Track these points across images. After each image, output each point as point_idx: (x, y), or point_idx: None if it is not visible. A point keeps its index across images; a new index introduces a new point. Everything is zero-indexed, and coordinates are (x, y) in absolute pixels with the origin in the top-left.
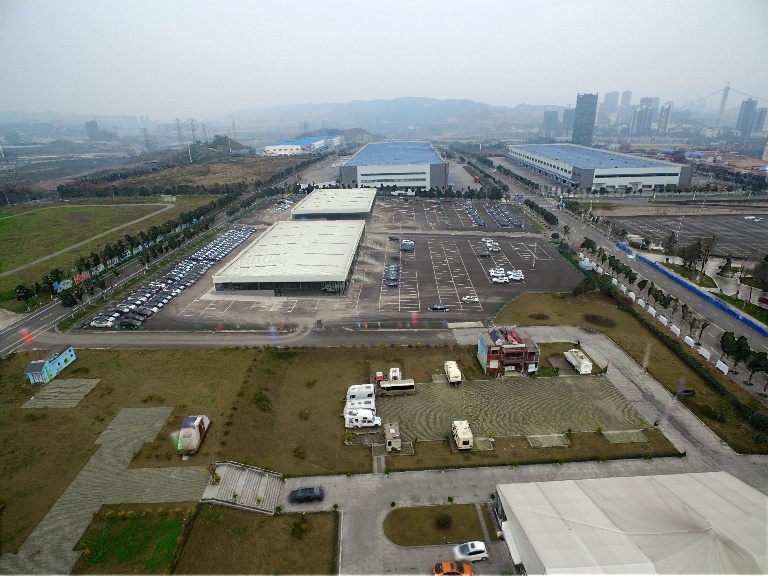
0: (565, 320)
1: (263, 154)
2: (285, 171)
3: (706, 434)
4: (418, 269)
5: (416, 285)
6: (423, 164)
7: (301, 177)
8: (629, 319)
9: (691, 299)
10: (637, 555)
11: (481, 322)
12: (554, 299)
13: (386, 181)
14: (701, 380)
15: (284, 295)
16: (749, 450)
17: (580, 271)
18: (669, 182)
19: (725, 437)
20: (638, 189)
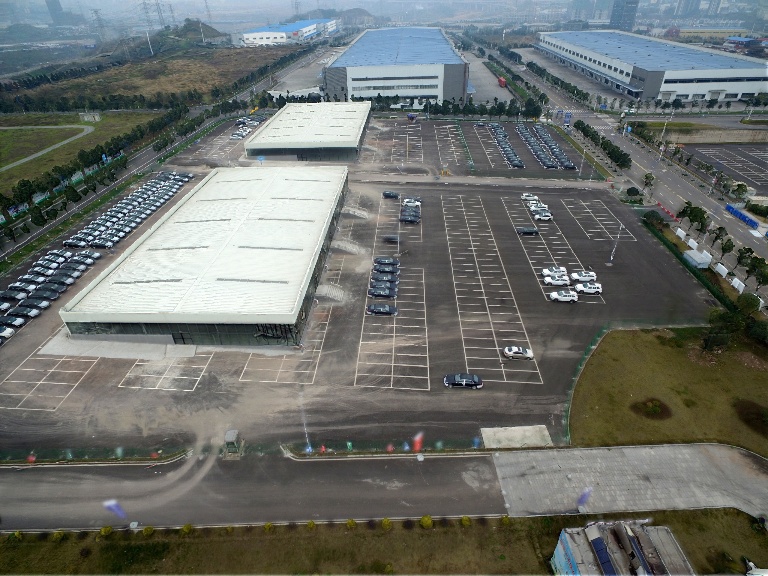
0: (704, 422)
1: (241, 44)
2: (257, 71)
3: None
4: (426, 266)
5: (423, 308)
6: (435, 64)
7: (278, 80)
8: None
9: None
10: None
11: (545, 428)
12: (664, 348)
13: (385, 88)
14: None
15: (191, 342)
16: None
17: (687, 269)
18: (763, 90)
19: None
20: (719, 99)
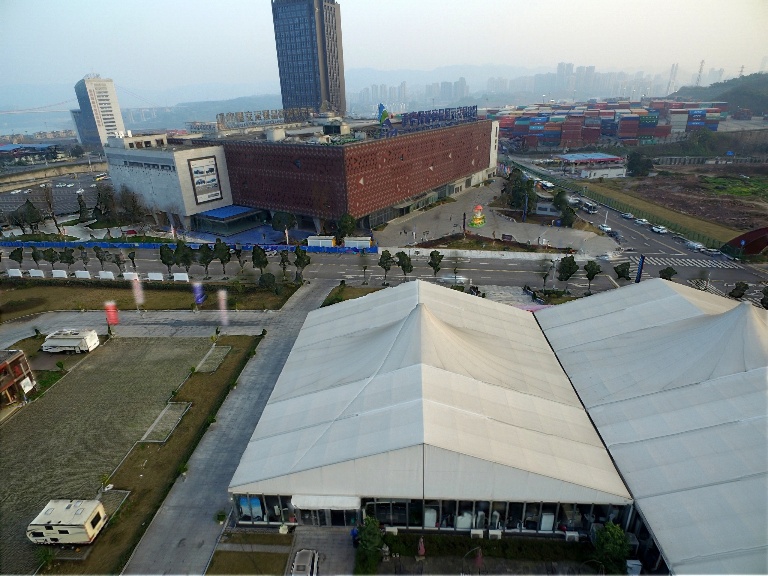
0: None
1: None
2: None
3: (249, 314)
4: None
5: None
6: None
7: None
8: (48, 289)
9: (75, 253)
10: (409, 371)
11: None
12: None
13: None
14: (184, 292)
15: None
16: (279, 304)
17: None
18: None
19: (258, 308)
20: None
